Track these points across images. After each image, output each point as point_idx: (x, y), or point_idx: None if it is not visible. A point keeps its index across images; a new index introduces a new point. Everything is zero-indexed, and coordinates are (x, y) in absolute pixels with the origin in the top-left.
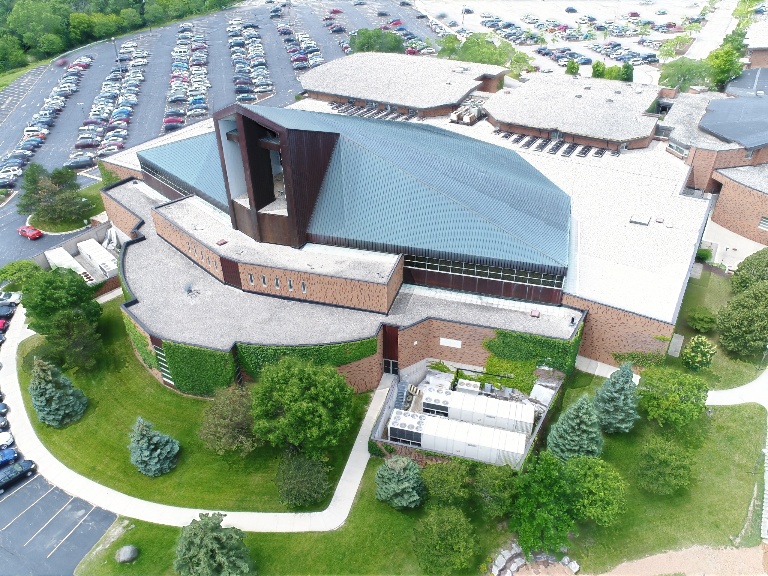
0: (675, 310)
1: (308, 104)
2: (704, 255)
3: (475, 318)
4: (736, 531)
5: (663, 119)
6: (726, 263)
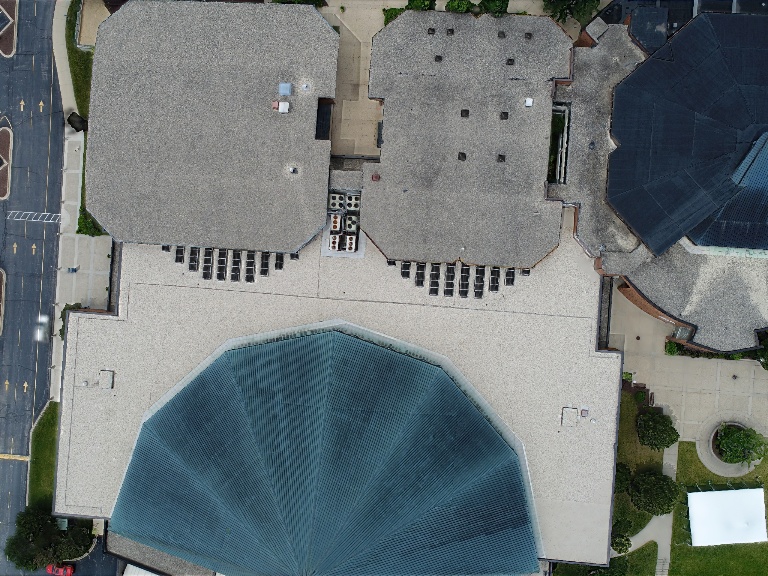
0: (608, 549)
1: (139, 259)
2: None
3: None
4: None
5: (565, 179)
6: (632, 368)
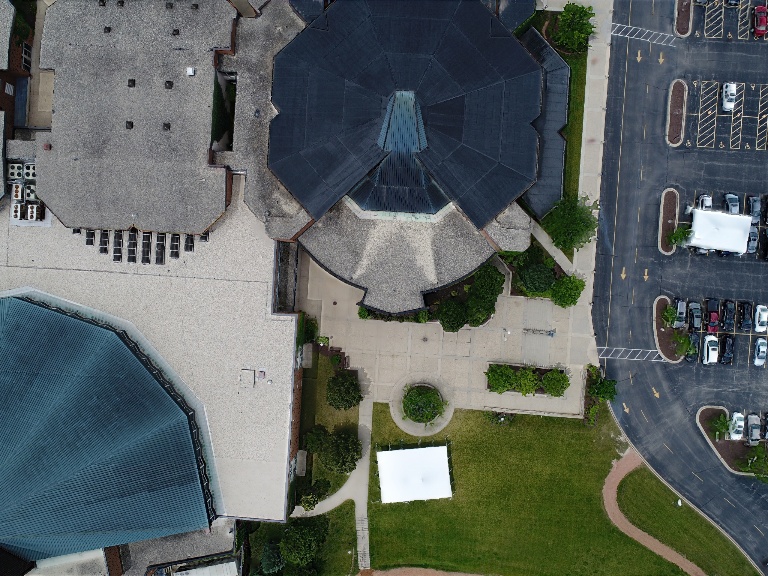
0: (284, 506)
1: None
2: (311, 336)
3: (175, 551)
4: (348, 572)
5: (232, 146)
6: (329, 333)
